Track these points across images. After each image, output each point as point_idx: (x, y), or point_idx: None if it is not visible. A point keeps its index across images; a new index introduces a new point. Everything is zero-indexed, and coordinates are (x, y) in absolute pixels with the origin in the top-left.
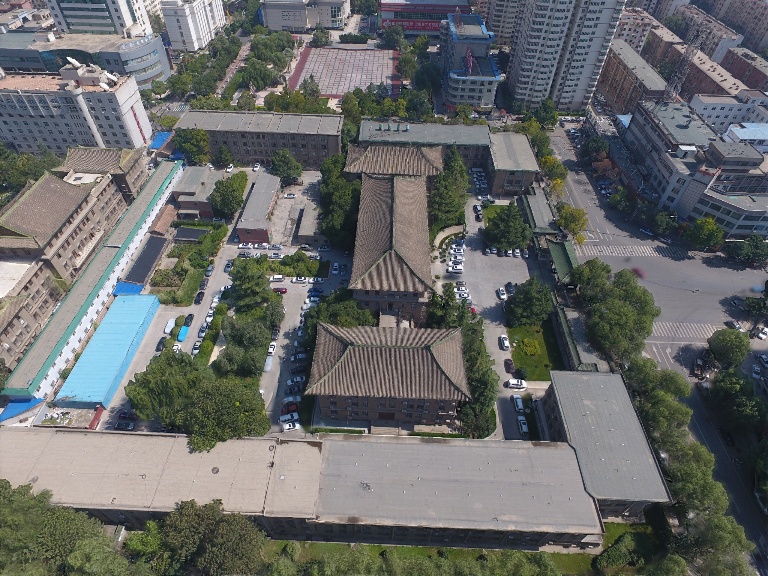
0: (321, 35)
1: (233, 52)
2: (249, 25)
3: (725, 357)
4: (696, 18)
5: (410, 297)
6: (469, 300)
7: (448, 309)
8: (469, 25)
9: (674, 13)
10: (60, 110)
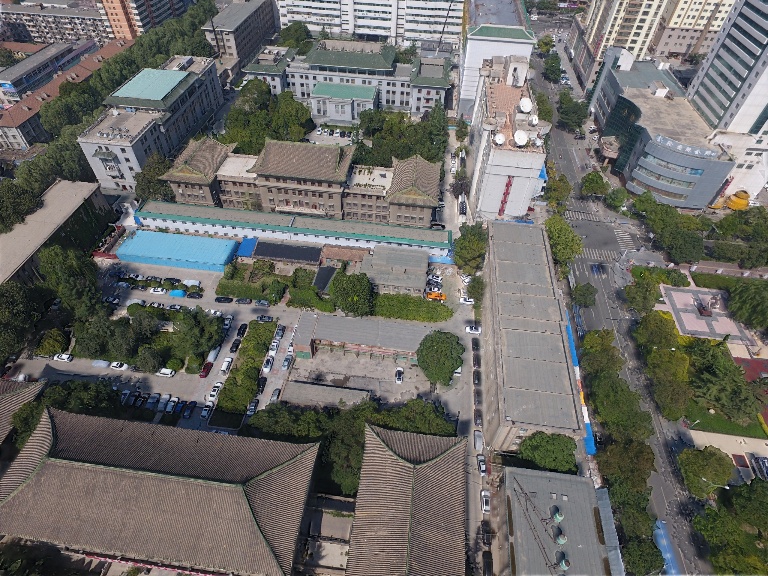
0: None
1: None
2: None
3: None
4: None
5: None
6: None
7: None
8: None
9: None
10: None
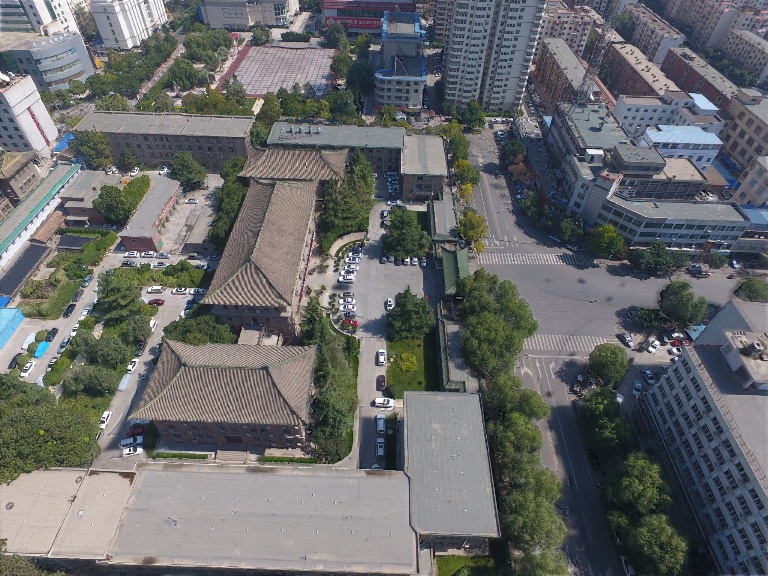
0: (260, 33)
1: (165, 50)
2: (189, 23)
3: (602, 373)
4: (641, 17)
5: (271, 311)
6: (352, 312)
7: (315, 323)
8: (403, 23)
9: (623, 12)
10: None
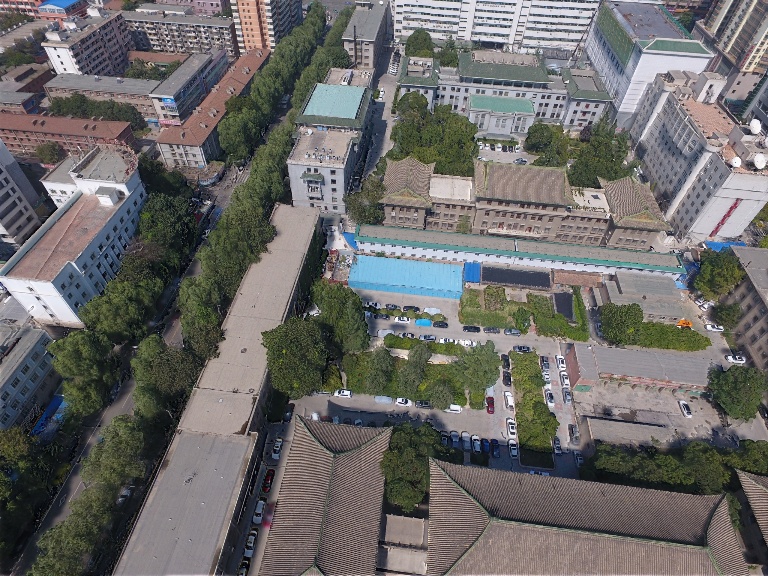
0: None
1: None
2: None
3: None
4: None
5: None
6: None
7: None
8: None
9: None
10: (690, 152)
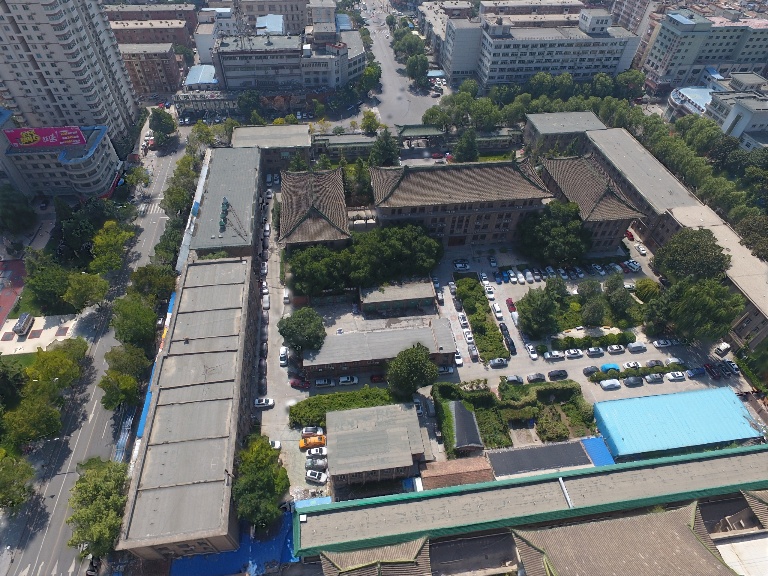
0: None
1: None
2: None
3: None
4: None
5: None
6: None
7: None
8: None
9: None
10: None
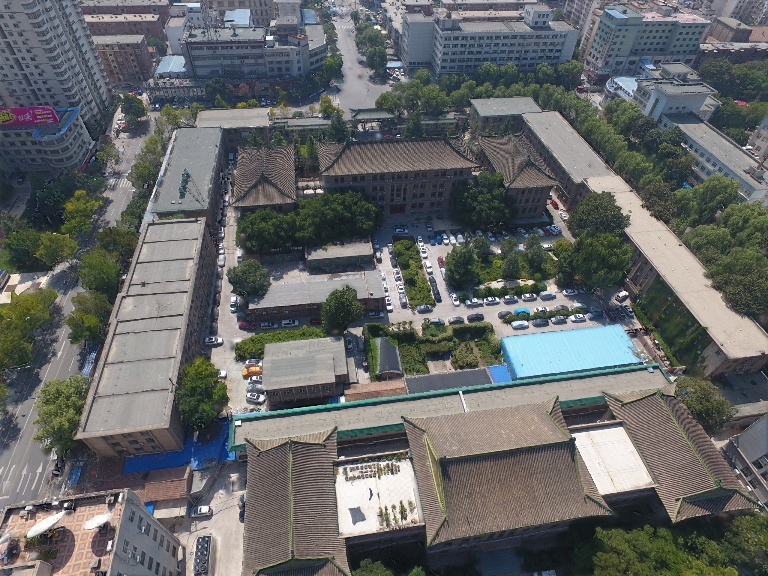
0: None
1: None
2: None
3: None
4: None
5: None
6: None
7: None
8: None
9: None
10: None
